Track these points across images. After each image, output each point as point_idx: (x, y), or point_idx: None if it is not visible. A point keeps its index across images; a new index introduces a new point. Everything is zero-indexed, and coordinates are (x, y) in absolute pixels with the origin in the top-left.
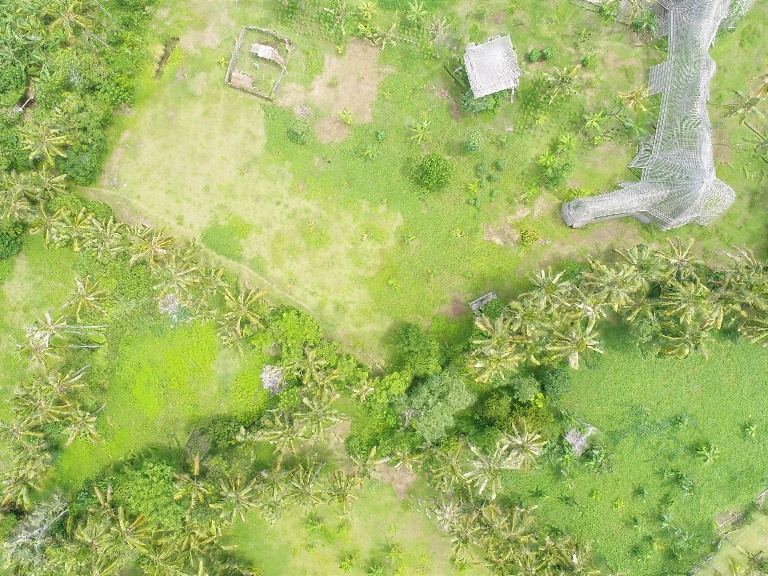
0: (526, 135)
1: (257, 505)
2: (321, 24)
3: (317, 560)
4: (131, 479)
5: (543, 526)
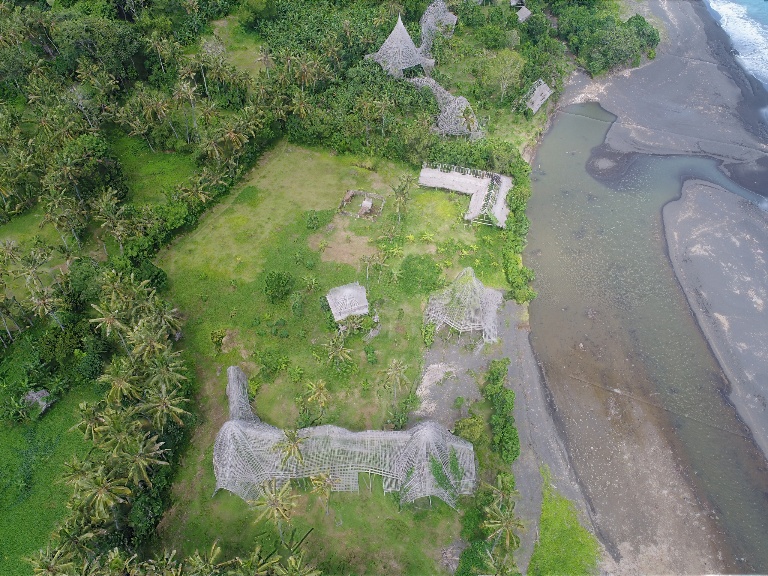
0: (308, 353)
1: None
2: None
3: None
4: None
5: None
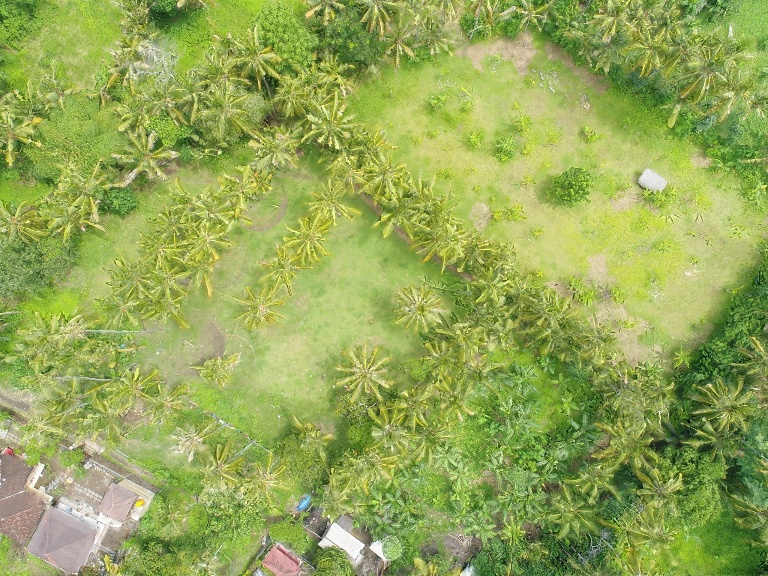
0: None
1: (399, 0)
2: None
3: (440, 147)
4: (252, 25)
5: (670, 88)
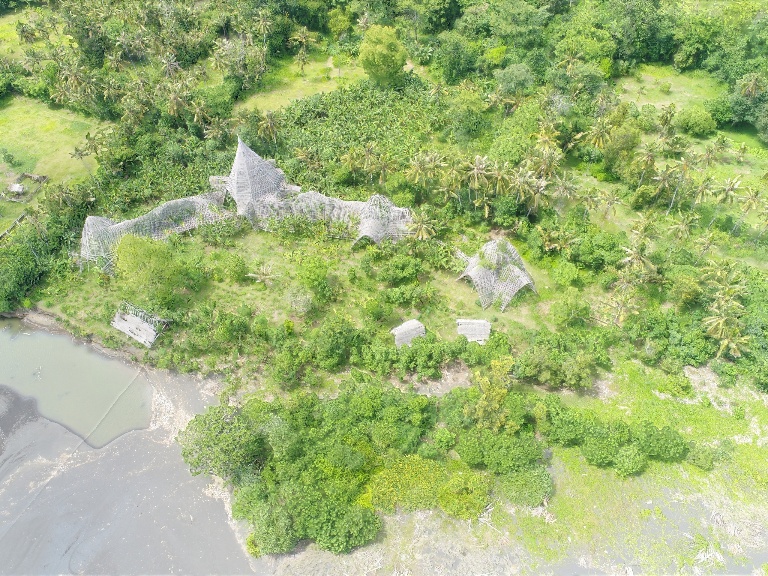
0: None
1: None
2: None
3: None
4: None
5: None
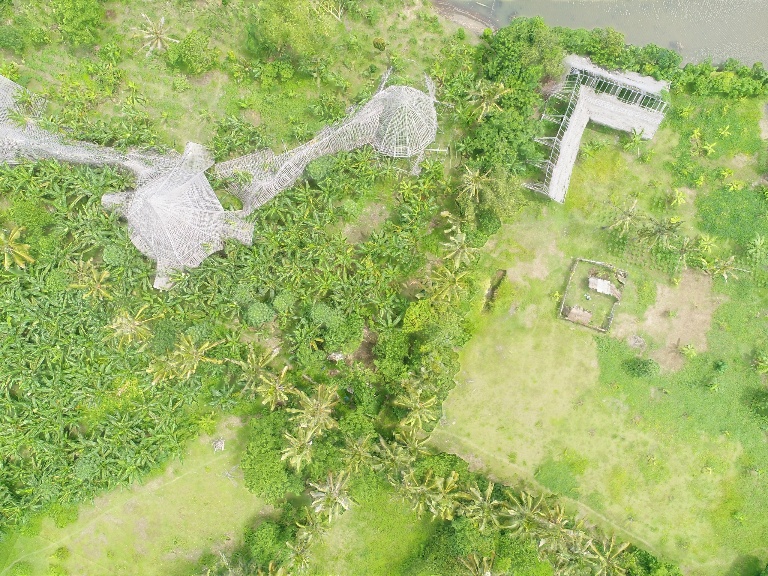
0: None
1: None
2: (652, 254)
3: None
4: None
5: None
